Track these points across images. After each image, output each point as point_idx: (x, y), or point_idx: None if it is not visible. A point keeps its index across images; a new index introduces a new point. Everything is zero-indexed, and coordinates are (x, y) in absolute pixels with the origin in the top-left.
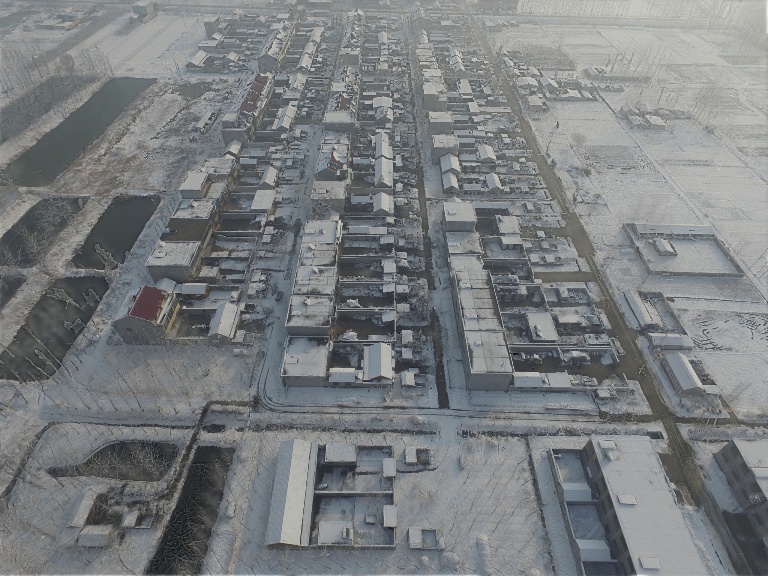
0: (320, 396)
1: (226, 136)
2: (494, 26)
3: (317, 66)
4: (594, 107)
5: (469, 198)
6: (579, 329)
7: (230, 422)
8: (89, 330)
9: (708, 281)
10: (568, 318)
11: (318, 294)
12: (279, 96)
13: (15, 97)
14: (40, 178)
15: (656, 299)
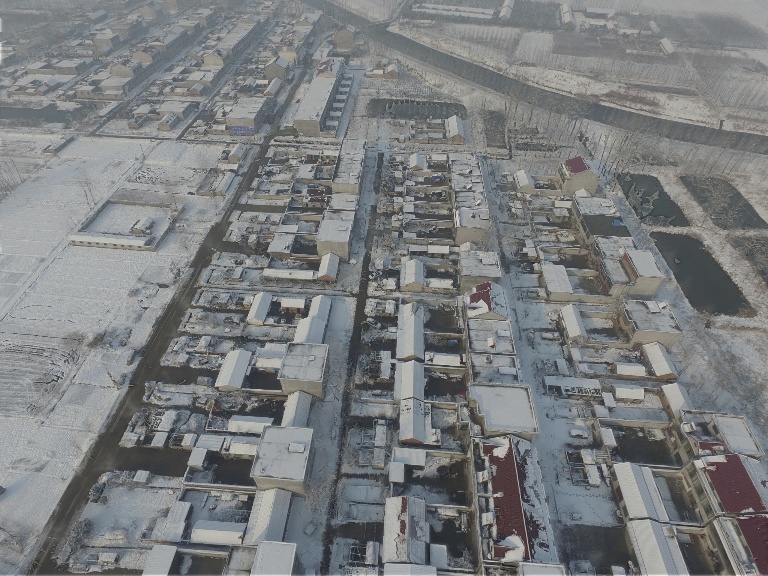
0: None
1: None
2: None
3: None
4: None
5: (302, 296)
6: None
7: None
8: None
9: None
10: (284, 177)
11: (463, 175)
12: None
13: None
14: None
15: (203, 190)
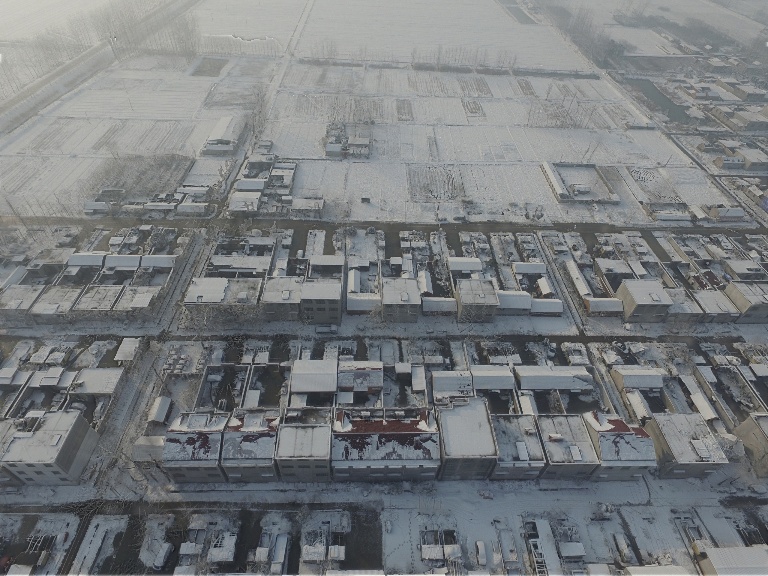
0: None
1: None
2: None
3: None
4: (313, 169)
5: (560, 295)
6: None
7: None
8: None
9: None
10: (719, 252)
11: None
12: None
13: None
14: None
15: (650, 208)
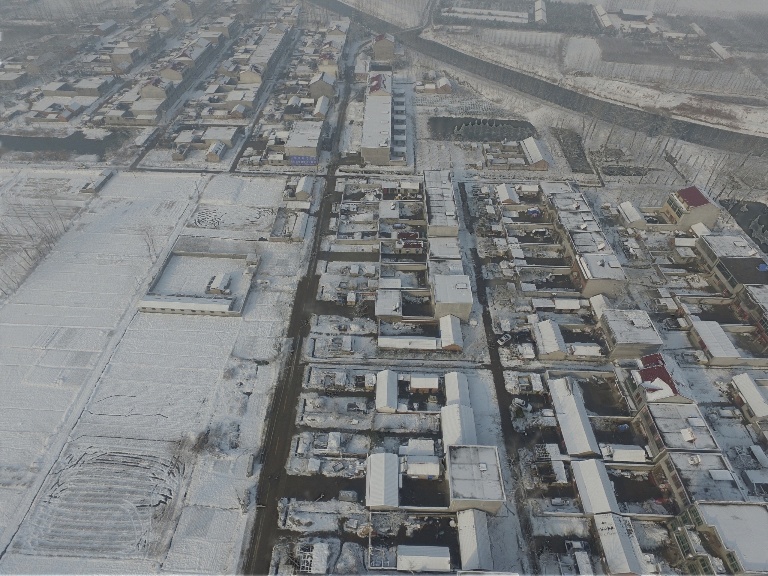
0: None
1: None
2: None
3: None
4: None
5: (428, 370)
6: None
7: None
8: None
9: None
10: (365, 217)
11: (570, 211)
12: None
13: None
14: None
15: (277, 236)
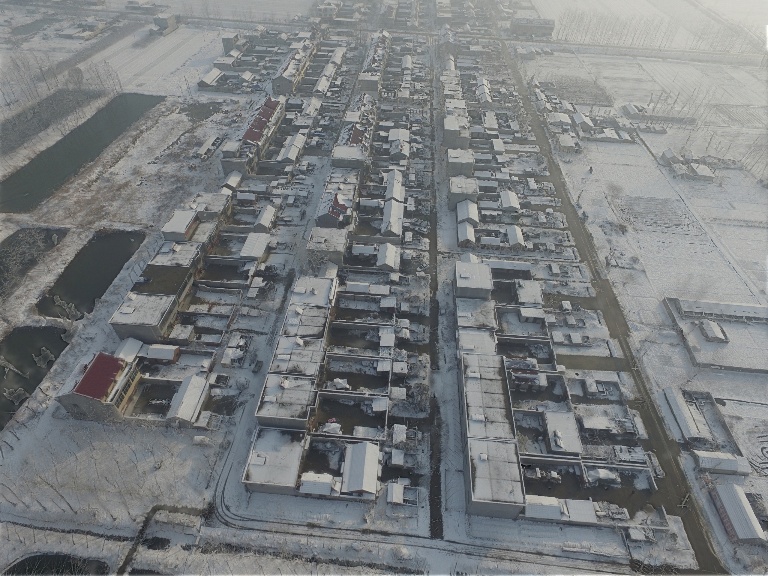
0: (288, 508)
1: (226, 166)
2: (526, 53)
3: (334, 90)
4: (632, 150)
5: (486, 254)
6: (608, 436)
7: (176, 536)
8: (36, 397)
9: (767, 380)
10: (595, 422)
11: (299, 374)
12: (290, 122)
13: (11, 113)
14: (24, 203)
15: (703, 401)
